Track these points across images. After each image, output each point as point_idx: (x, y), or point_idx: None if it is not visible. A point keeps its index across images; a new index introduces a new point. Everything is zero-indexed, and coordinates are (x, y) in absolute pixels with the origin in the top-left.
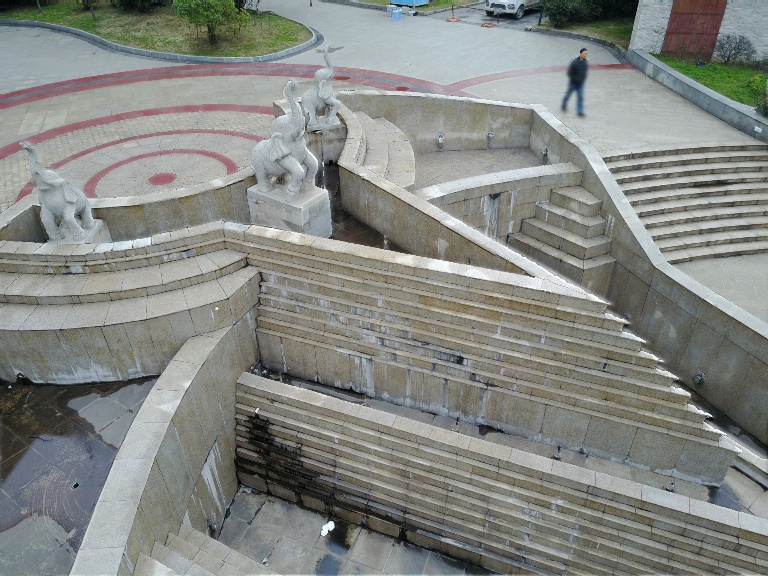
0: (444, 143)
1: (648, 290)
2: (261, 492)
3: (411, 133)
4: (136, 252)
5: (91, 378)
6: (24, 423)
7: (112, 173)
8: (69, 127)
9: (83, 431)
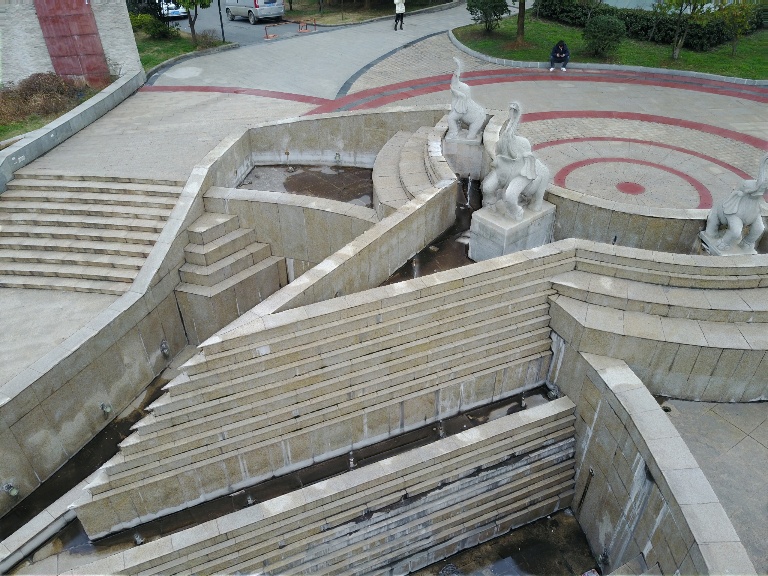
0: None
1: None
2: None
3: None
4: None
5: None
6: None
7: (641, 166)
8: (756, 141)
9: None
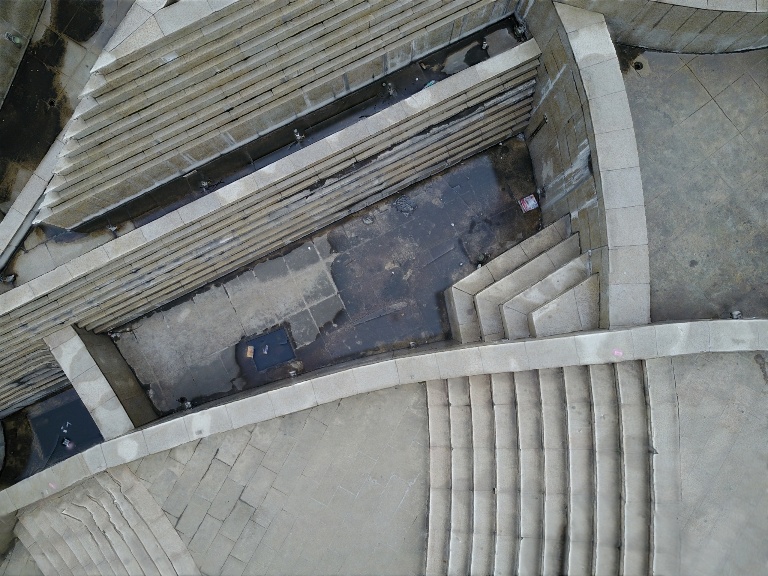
0: None
1: None
2: None
3: None
4: None
5: None
6: None
7: None
8: None
9: None
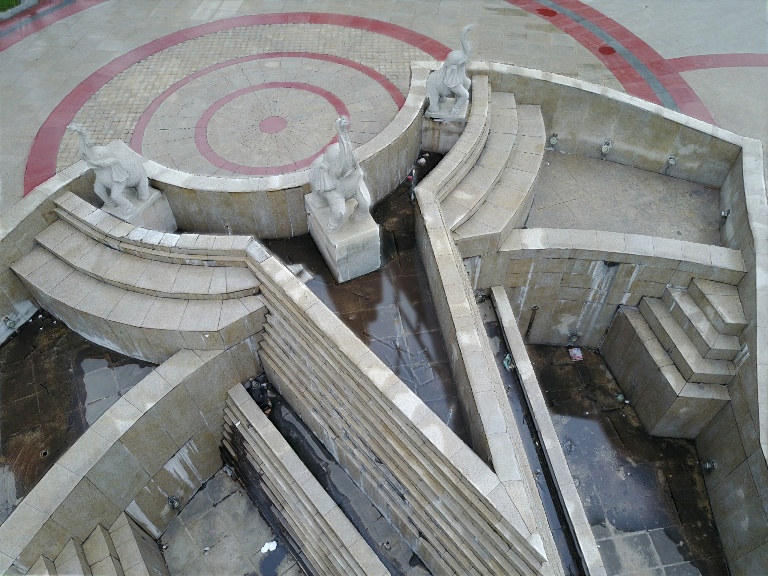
0: (610, 152)
1: (743, 460)
2: (238, 480)
3: (571, 130)
4: (162, 248)
5: (106, 345)
6: (45, 367)
7: (235, 101)
8: (236, 21)
9: (77, 398)
